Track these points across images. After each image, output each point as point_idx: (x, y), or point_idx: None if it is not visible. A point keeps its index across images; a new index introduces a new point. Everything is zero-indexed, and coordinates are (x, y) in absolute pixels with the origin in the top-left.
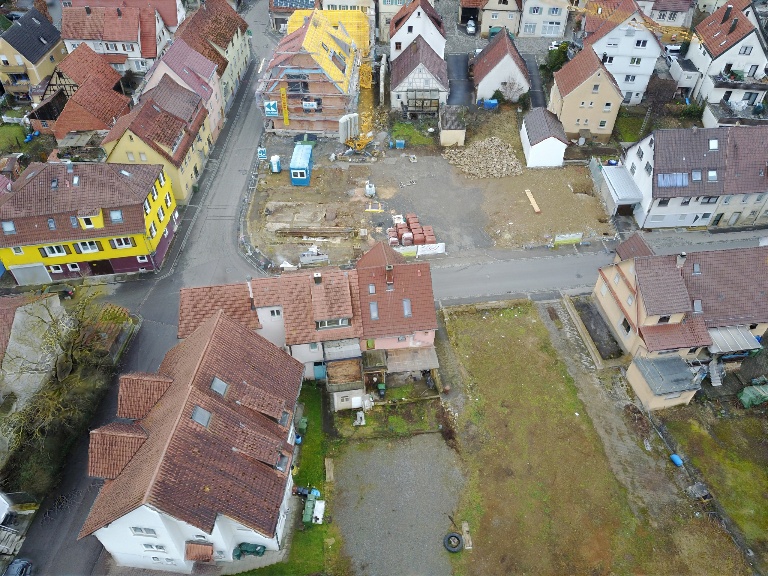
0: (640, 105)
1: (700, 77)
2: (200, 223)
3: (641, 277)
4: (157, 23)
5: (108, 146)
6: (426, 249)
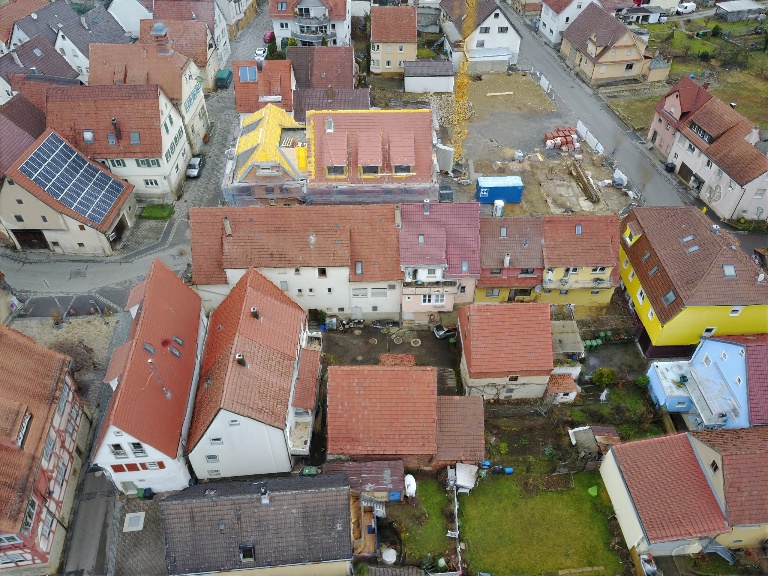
0: None
1: None
2: None
3: None
4: None
5: None
6: None
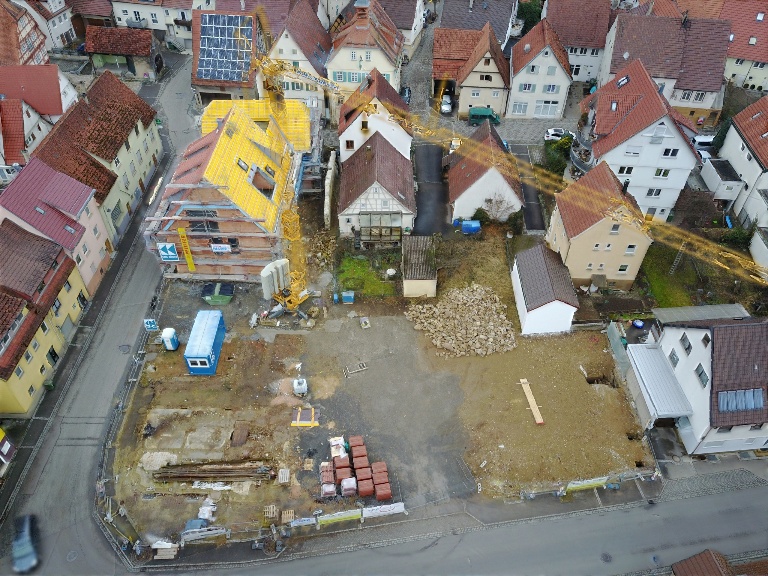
0: (670, 235)
1: (744, 188)
2: (45, 454)
3: None
4: (26, 118)
5: None
6: (375, 512)
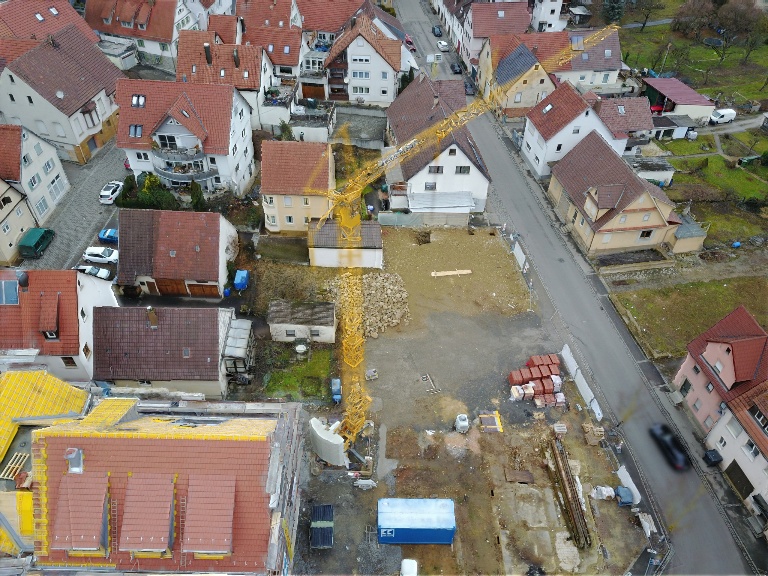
0: None
1: None
2: None
3: None
4: None
5: None
6: None
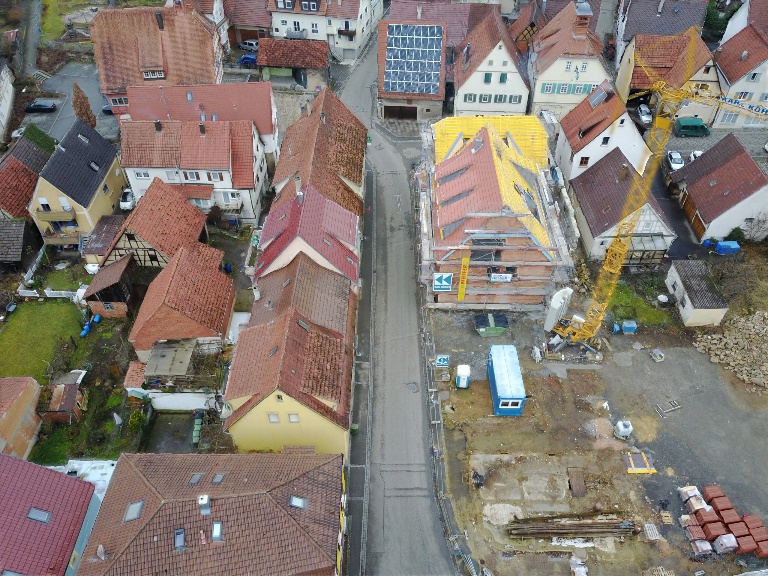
0: None
1: None
2: (378, 506)
3: None
4: (253, 140)
5: (236, 401)
6: None
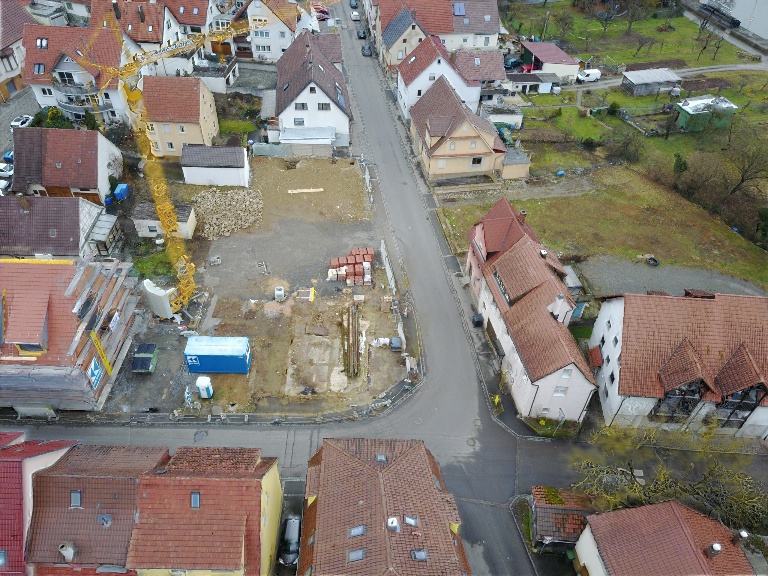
0: None
1: (154, 65)
2: None
3: (476, 125)
4: None
5: None
6: None
